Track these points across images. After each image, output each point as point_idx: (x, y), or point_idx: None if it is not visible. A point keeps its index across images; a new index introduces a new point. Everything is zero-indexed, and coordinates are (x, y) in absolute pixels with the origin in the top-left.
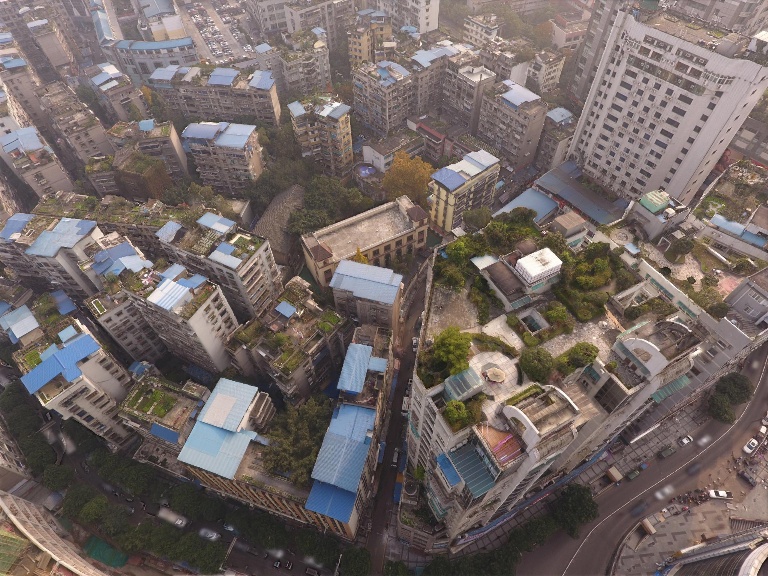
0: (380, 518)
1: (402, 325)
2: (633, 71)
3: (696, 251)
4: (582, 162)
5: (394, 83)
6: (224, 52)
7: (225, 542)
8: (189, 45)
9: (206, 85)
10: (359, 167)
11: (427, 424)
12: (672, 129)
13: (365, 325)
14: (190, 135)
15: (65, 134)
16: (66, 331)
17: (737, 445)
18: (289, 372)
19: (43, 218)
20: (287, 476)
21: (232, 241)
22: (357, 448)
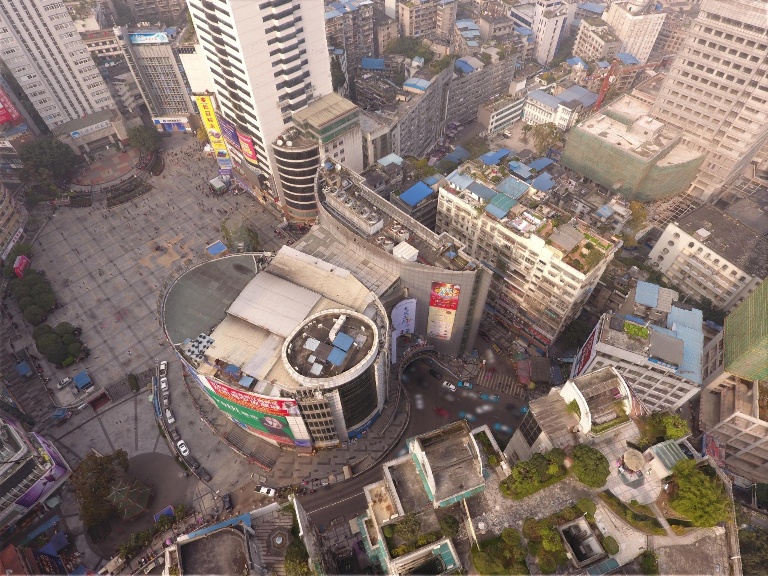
0: None
1: None
2: None
3: None
4: None
5: None
6: None
7: (764, 508)
8: None
9: None
10: None
11: None
12: None
13: None
14: None
15: None
16: None
17: None
18: None
19: None
20: None
21: None
22: None
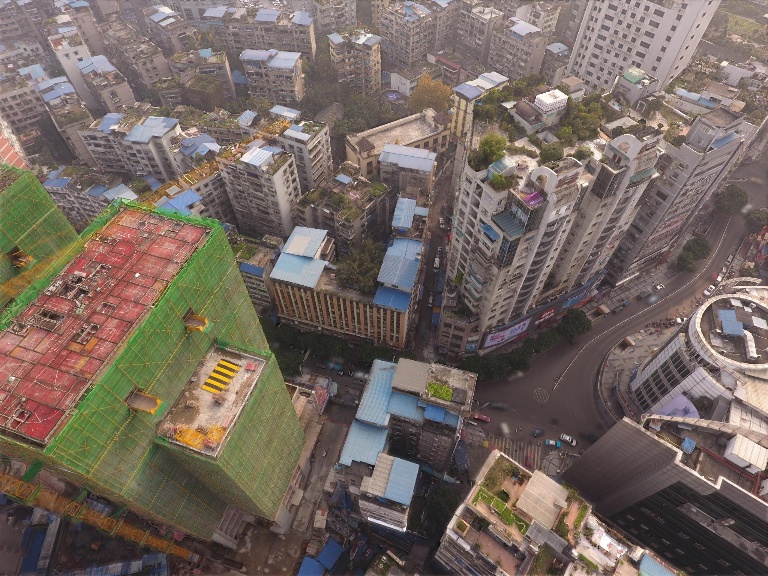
0: (421, 340)
1: (431, 208)
2: None
3: (665, 112)
4: None
5: (418, 19)
6: (255, 6)
7: None
8: None
9: (253, 22)
10: (387, 93)
11: (472, 214)
12: (649, 40)
13: (409, 187)
14: (247, 58)
15: (134, 60)
16: (172, 189)
17: (699, 291)
18: (351, 221)
19: (133, 116)
20: (356, 288)
21: None
22: (410, 263)
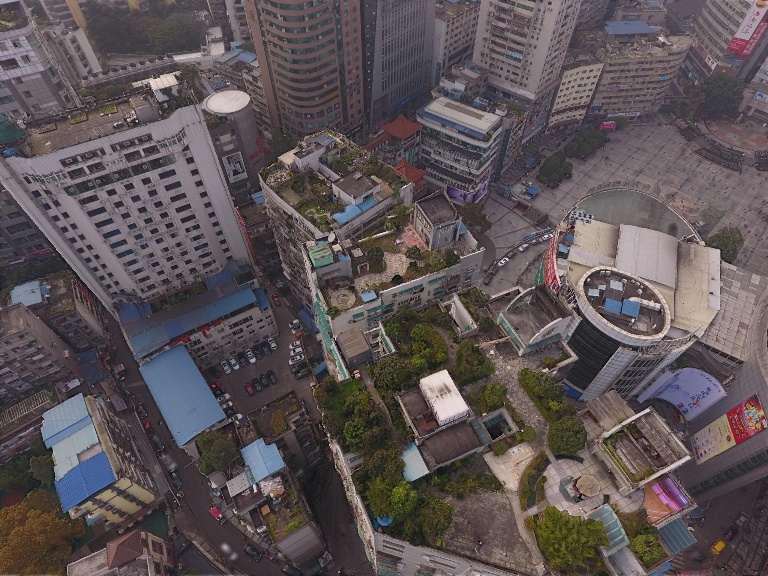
0: None
1: None
2: (88, 196)
3: None
4: (134, 298)
5: None
6: None
7: None
8: None
9: None
10: None
11: None
12: (184, 202)
13: None
14: None
15: None
16: None
17: None
18: None
19: None
20: None
21: None
22: None
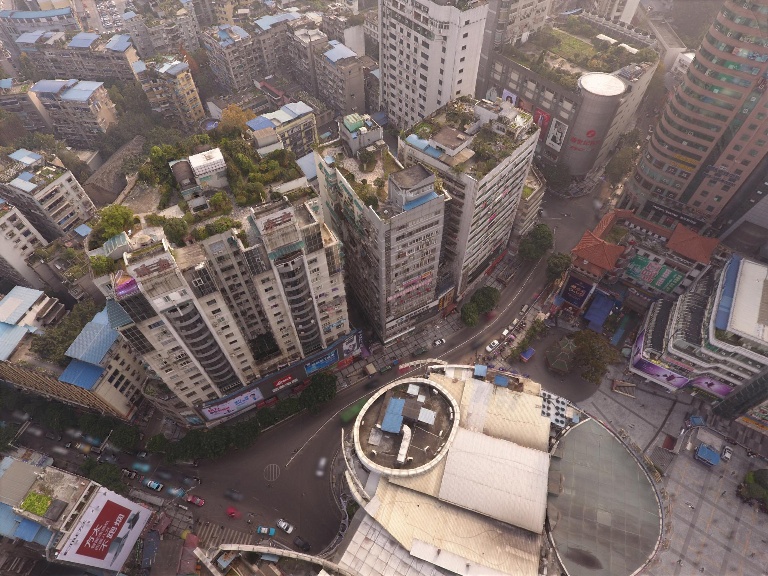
0: None
1: None
2: (393, 23)
3: (386, 163)
4: (387, 111)
5: (232, 44)
6: (114, 24)
7: (18, 425)
8: (68, 14)
9: (68, 48)
10: (207, 122)
11: None
12: (425, 73)
13: None
14: (37, 89)
15: None
16: None
17: (482, 346)
18: (74, 279)
19: None
20: None
21: (39, 172)
22: (109, 333)
